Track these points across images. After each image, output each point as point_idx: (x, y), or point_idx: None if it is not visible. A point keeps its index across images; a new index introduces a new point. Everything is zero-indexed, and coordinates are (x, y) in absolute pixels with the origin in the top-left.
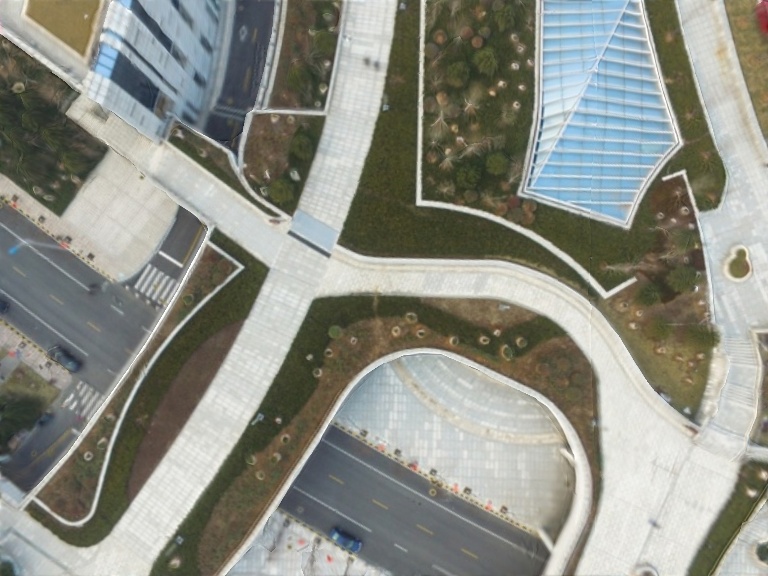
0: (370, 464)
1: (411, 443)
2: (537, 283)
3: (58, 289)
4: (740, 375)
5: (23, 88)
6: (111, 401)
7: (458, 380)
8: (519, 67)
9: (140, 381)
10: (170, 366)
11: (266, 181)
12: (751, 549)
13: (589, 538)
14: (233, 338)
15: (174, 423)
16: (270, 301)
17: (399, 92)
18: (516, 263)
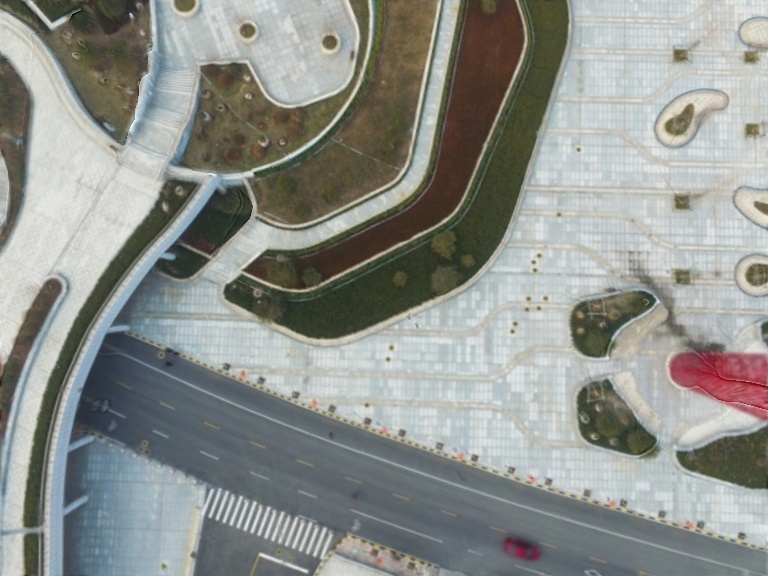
0: None
1: None
2: None
3: None
4: (173, 101)
5: None
6: None
7: None
8: None
9: None
10: None
11: None
12: (220, 290)
13: (4, 249)
14: None
15: None
16: None
17: None
18: None
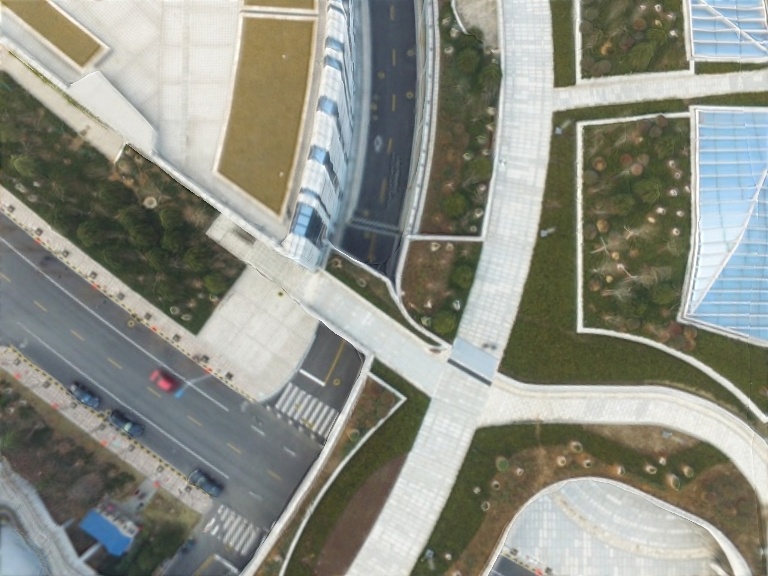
0: None
1: (562, 561)
2: (698, 409)
3: (195, 410)
4: None
5: (155, 203)
6: (277, 542)
7: (607, 496)
8: (677, 193)
9: (306, 520)
10: (336, 503)
11: (427, 310)
12: None
13: None
14: (398, 472)
15: (341, 562)
16: (433, 432)
17: (557, 218)
18: (676, 388)
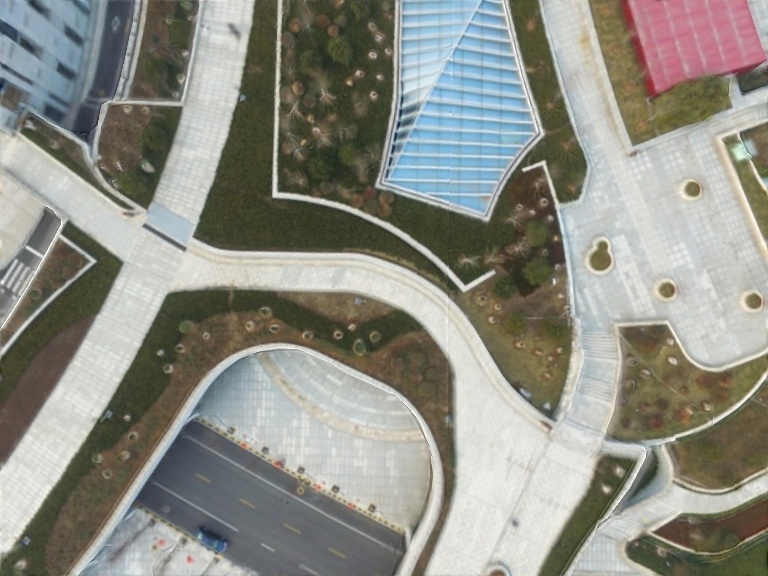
0: (237, 462)
1: (279, 441)
2: (395, 276)
3: None
4: (599, 369)
5: None
6: None
7: (327, 376)
8: (377, 56)
9: None
10: (17, 362)
11: (119, 173)
12: (620, 547)
13: (440, 536)
14: (84, 334)
15: (21, 421)
16: (123, 296)
17: (256, 82)
18: (375, 256)
